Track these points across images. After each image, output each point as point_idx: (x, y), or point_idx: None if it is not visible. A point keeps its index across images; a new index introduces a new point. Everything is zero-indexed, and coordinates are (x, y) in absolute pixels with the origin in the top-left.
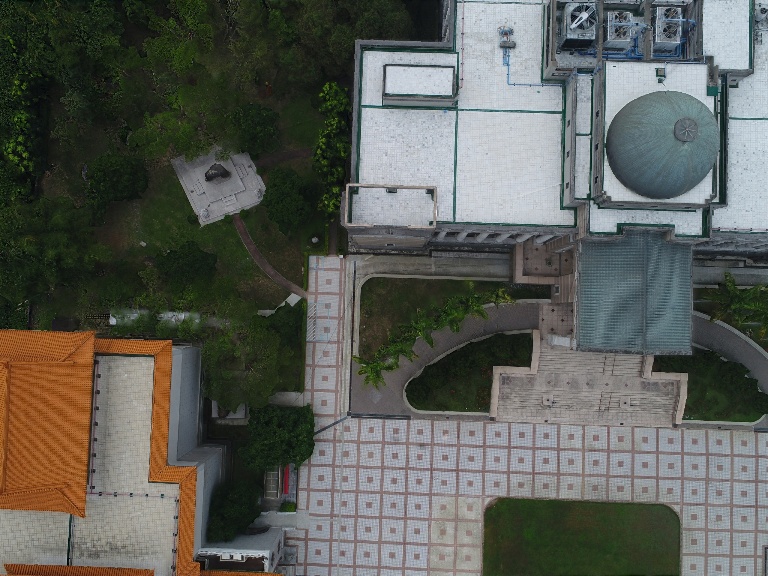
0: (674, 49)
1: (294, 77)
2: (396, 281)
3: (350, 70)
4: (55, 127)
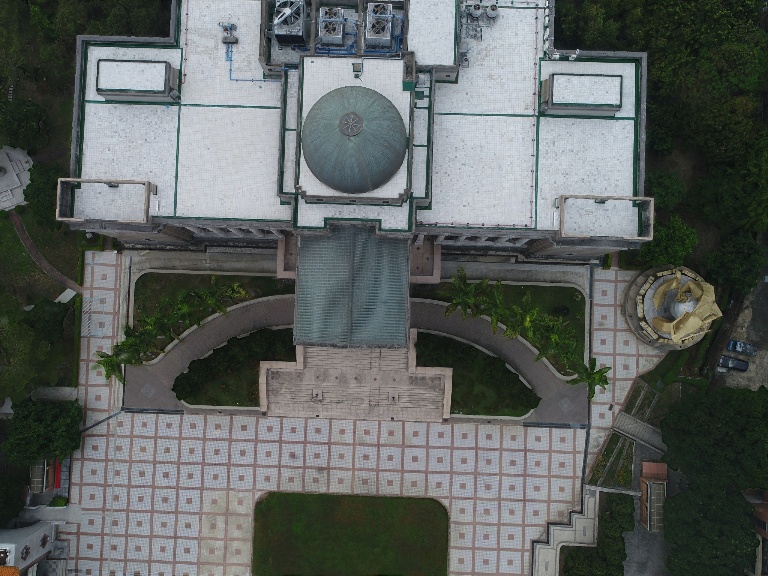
0: (394, 45)
1: (59, 73)
2: (170, 276)
3: None
4: None
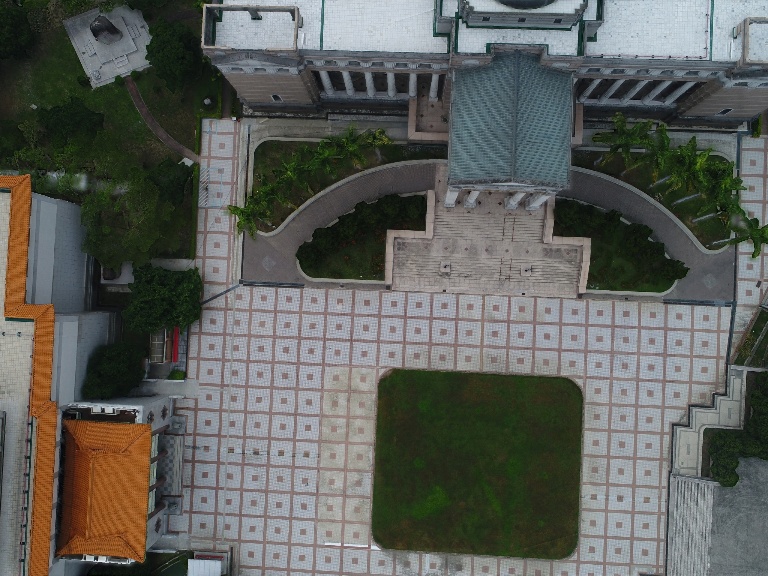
0: None
1: None
2: (291, 145)
3: None
4: None
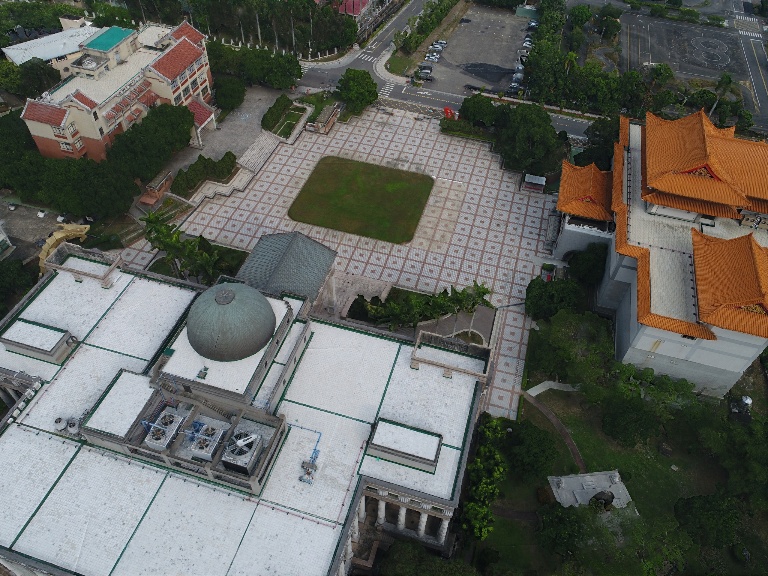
0: None
1: (516, 571)
2: None
3: None
4: None
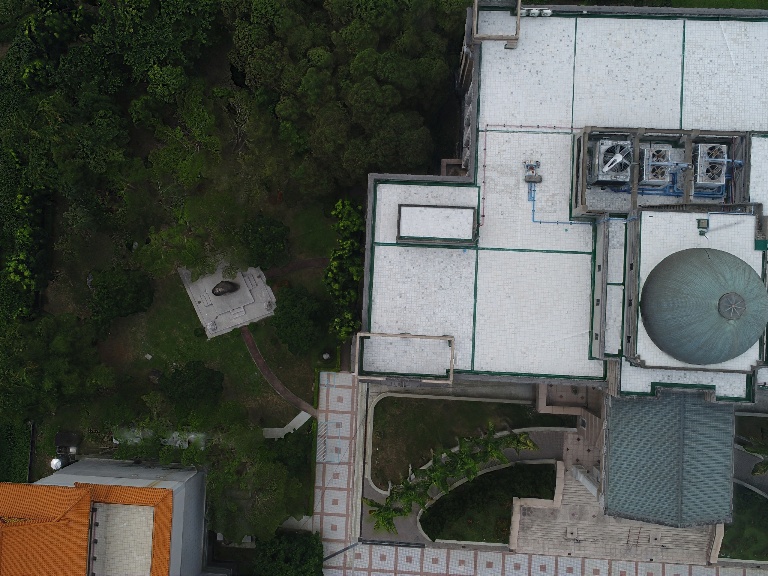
0: None
1: (305, 190)
2: (411, 401)
3: (365, 182)
4: (60, 234)
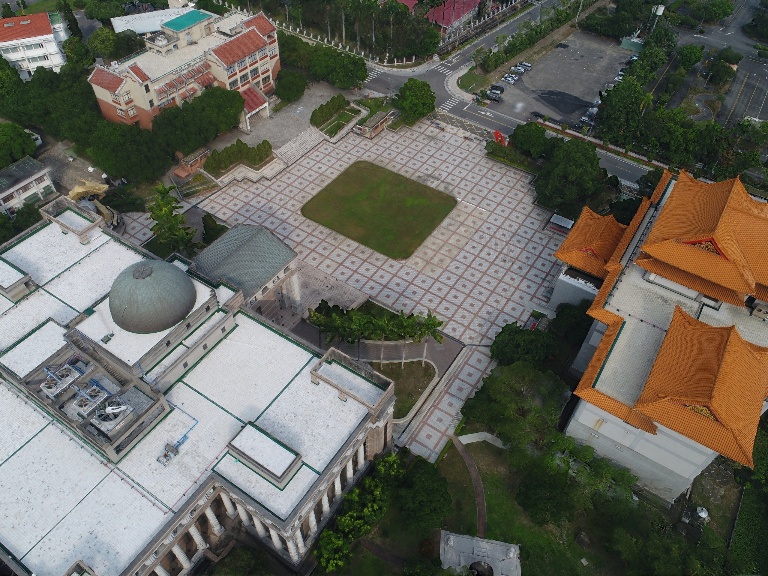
0: None
1: None
2: None
3: None
4: None
